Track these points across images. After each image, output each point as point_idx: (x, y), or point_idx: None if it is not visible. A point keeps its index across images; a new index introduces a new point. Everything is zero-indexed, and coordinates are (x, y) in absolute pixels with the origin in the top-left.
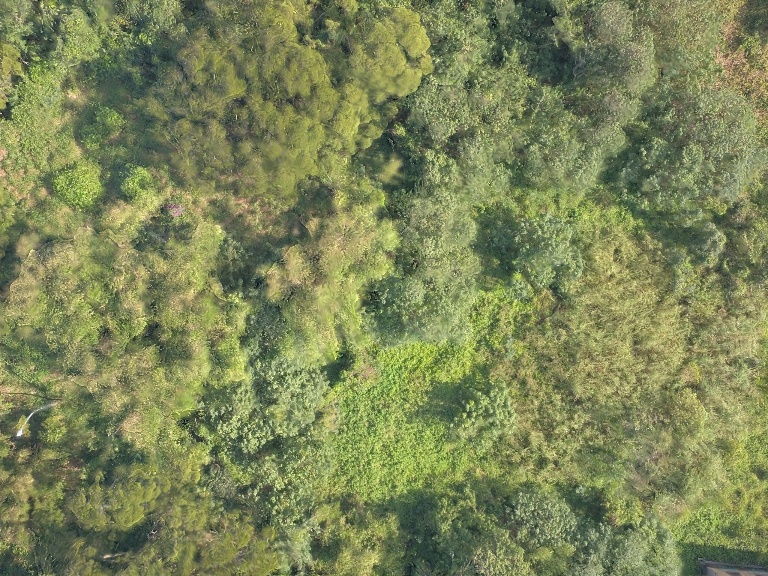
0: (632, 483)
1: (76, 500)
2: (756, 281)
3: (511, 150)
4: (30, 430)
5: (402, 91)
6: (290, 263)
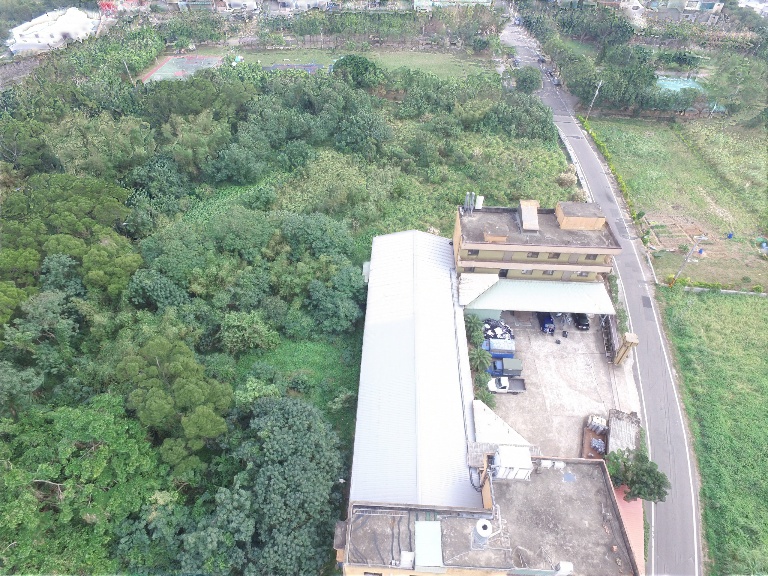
0: (326, 201)
1: (33, 176)
2: (391, 160)
3: (285, 120)
4: (24, 192)
5: (242, 98)
6: (178, 121)
